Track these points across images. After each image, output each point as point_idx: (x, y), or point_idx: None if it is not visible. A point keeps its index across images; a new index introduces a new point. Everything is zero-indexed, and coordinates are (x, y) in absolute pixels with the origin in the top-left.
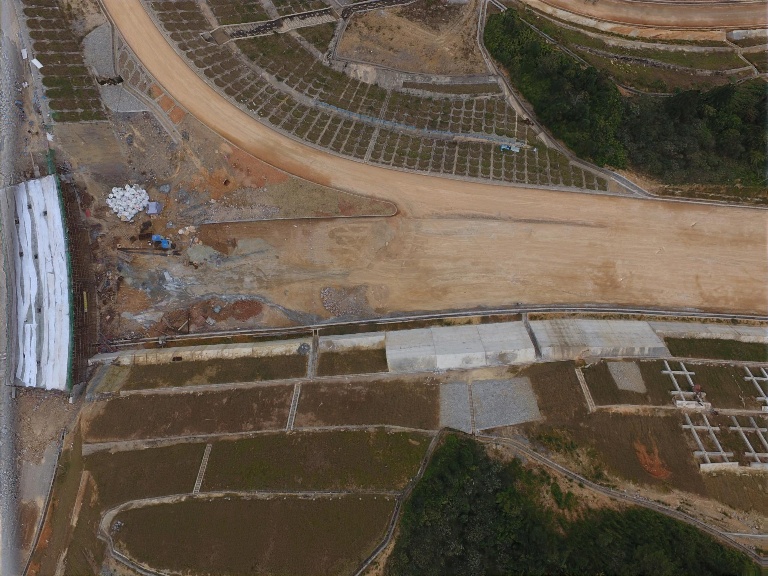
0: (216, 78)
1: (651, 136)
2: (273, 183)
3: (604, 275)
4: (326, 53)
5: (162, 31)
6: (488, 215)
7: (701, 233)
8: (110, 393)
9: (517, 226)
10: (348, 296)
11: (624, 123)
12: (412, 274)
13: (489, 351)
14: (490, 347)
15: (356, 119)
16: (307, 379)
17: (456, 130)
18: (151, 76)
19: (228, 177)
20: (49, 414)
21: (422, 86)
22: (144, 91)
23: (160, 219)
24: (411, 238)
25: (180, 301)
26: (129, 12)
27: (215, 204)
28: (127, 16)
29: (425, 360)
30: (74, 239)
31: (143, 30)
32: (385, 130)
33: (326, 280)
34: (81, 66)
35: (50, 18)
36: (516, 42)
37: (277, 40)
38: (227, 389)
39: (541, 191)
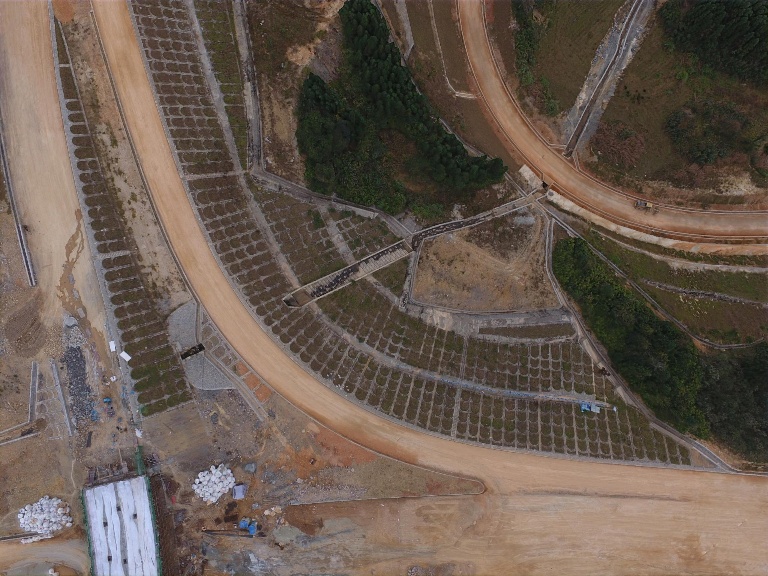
0: (301, 352)
1: (733, 408)
2: (360, 463)
3: (688, 548)
4: (402, 297)
5: (248, 307)
6: (574, 491)
7: None
8: None
9: (603, 501)
10: None
11: (704, 387)
12: (499, 551)
13: None
14: None
15: (437, 379)
16: None
17: (536, 388)
18: (237, 354)
19: (314, 455)
20: None
21: (498, 331)
22: (228, 366)
23: (245, 500)
24: (498, 515)
25: None
26: (214, 288)
27: (302, 485)
28: (212, 292)
29: None
30: (163, 537)
31: (228, 306)
32: (467, 391)
33: (413, 558)
34: (166, 346)
35: (136, 301)
36: (588, 280)
37: (354, 289)
38: None
39: (627, 466)
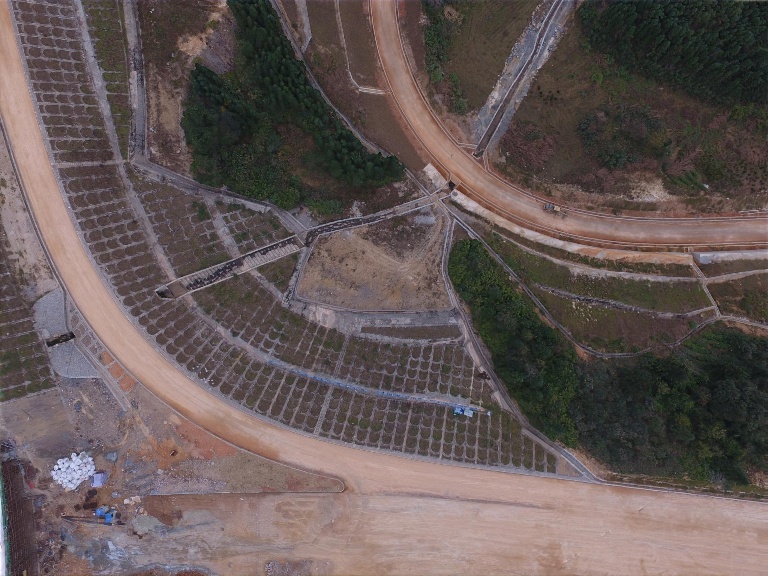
0: (168, 344)
1: (602, 417)
2: (221, 456)
3: (549, 556)
4: (286, 293)
5: (115, 297)
6: (436, 494)
7: (648, 517)
8: None
9: (464, 505)
10: (292, 573)
11: (577, 396)
12: (357, 550)
13: None
14: None
15: None
16: None
17: (411, 389)
18: (102, 344)
19: (176, 447)
20: None
21: (381, 330)
22: (95, 355)
23: (106, 488)
24: (358, 514)
25: (123, 570)
26: (82, 277)
27: (162, 476)
28: (80, 281)
29: None
30: (15, 521)
31: (96, 295)
32: (339, 389)
33: (271, 553)
34: (31, 333)
35: (0, 287)
36: (478, 283)
37: (236, 283)
38: None
39: (490, 472)
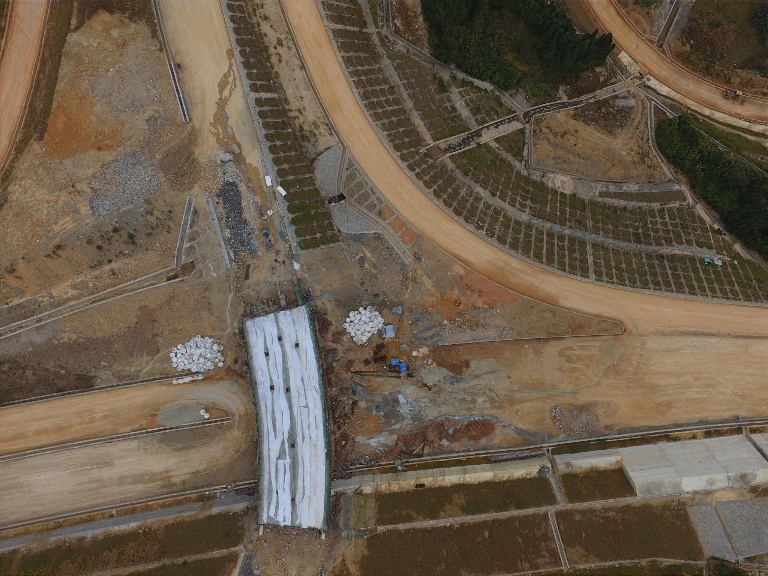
0: (443, 198)
1: None
2: (505, 304)
3: None
4: (523, 162)
5: (392, 153)
6: (708, 332)
7: None
8: (367, 529)
9: (735, 342)
10: (581, 415)
11: None
12: (638, 391)
13: (730, 472)
14: (729, 467)
15: (567, 233)
16: (560, 507)
17: (660, 243)
18: (383, 198)
19: (460, 298)
20: (303, 553)
21: (616, 195)
22: (373, 211)
23: (393, 341)
24: (636, 355)
25: (414, 423)
26: (359, 133)
27: (449, 326)
28: (357, 137)
29: (671, 483)
30: None
31: (373, 151)
32: (596, 244)
33: (556, 399)
34: (314, 188)
35: (286, 141)
36: (696, 151)
37: (480, 151)
38: (483, 520)
39: (756, 308)
